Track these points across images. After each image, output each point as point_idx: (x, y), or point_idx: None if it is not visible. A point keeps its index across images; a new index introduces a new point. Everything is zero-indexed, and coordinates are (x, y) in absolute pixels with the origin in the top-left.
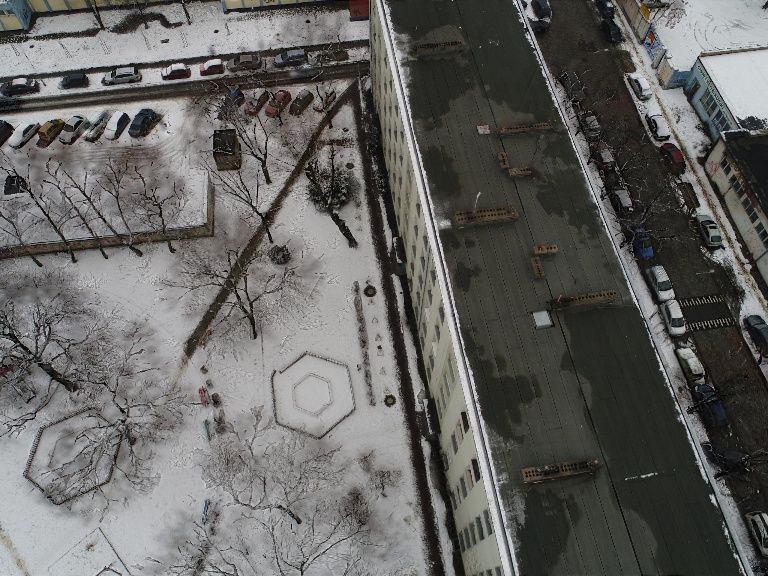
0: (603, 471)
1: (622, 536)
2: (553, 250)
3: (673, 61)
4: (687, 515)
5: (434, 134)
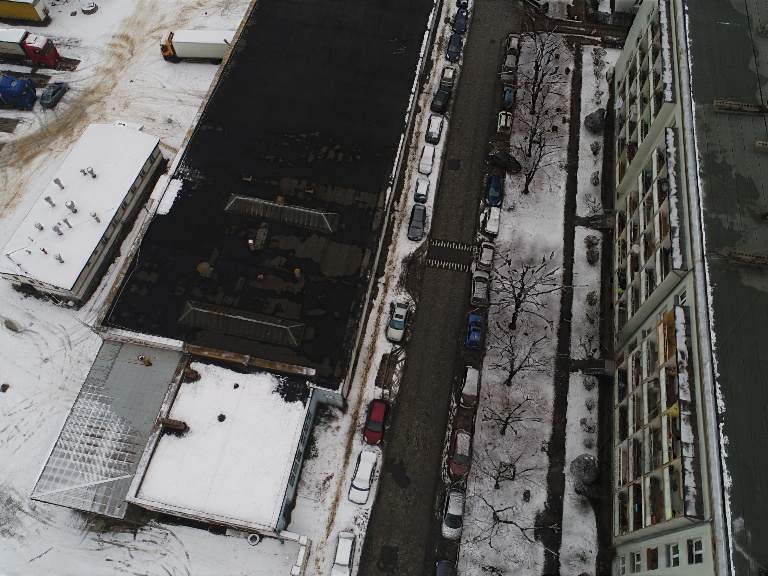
0: (754, 29)
1: (751, 6)
2: (762, 142)
3: None
4: (706, 6)
5: None
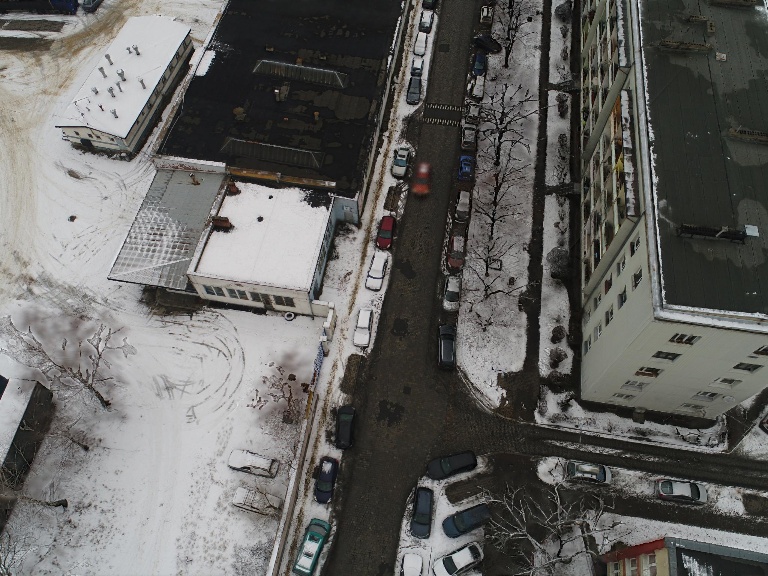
0: None
1: None
2: None
3: (296, 354)
4: None
5: (765, 66)
